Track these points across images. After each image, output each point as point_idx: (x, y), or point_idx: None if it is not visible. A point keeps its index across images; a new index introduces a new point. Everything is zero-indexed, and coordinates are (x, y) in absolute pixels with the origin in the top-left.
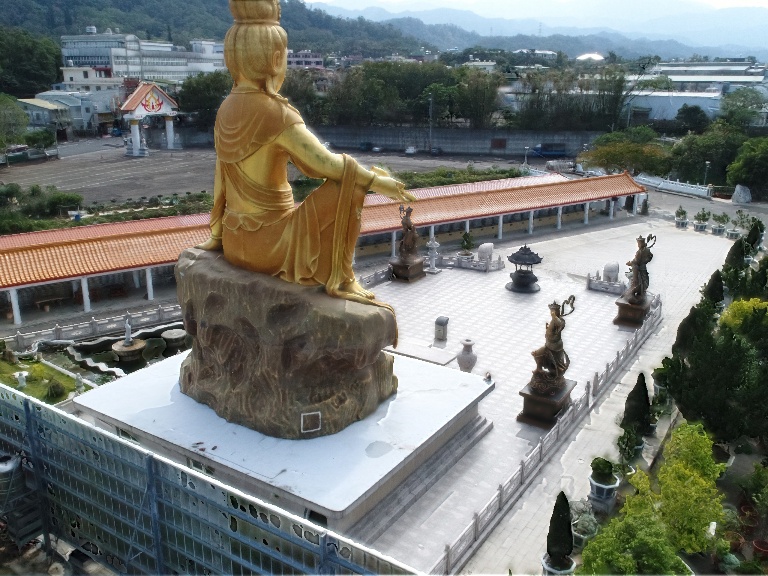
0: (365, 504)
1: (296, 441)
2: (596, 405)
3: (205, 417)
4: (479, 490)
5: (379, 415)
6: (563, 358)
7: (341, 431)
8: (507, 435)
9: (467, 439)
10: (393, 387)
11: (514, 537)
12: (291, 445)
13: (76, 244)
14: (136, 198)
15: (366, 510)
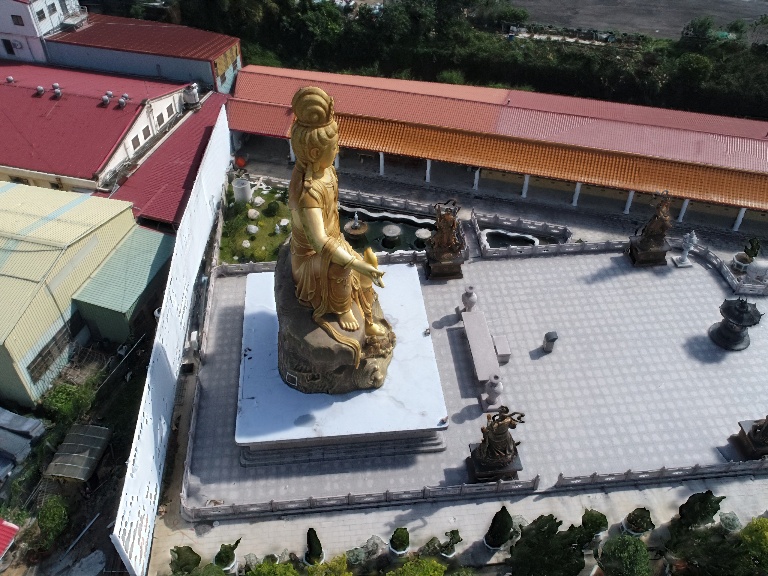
0: (280, 444)
1: (284, 383)
2: (546, 494)
3: (276, 332)
4: (362, 483)
5: (343, 398)
6: (507, 447)
7: (310, 394)
8: (440, 464)
9: (405, 447)
10: (374, 384)
11: (335, 524)
12: (278, 384)
13: (387, 122)
14: (585, 21)
15: (281, 447)
